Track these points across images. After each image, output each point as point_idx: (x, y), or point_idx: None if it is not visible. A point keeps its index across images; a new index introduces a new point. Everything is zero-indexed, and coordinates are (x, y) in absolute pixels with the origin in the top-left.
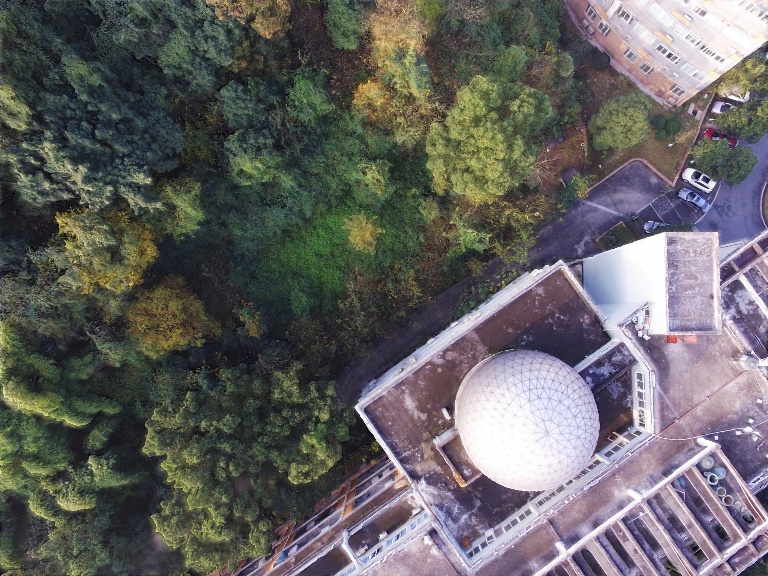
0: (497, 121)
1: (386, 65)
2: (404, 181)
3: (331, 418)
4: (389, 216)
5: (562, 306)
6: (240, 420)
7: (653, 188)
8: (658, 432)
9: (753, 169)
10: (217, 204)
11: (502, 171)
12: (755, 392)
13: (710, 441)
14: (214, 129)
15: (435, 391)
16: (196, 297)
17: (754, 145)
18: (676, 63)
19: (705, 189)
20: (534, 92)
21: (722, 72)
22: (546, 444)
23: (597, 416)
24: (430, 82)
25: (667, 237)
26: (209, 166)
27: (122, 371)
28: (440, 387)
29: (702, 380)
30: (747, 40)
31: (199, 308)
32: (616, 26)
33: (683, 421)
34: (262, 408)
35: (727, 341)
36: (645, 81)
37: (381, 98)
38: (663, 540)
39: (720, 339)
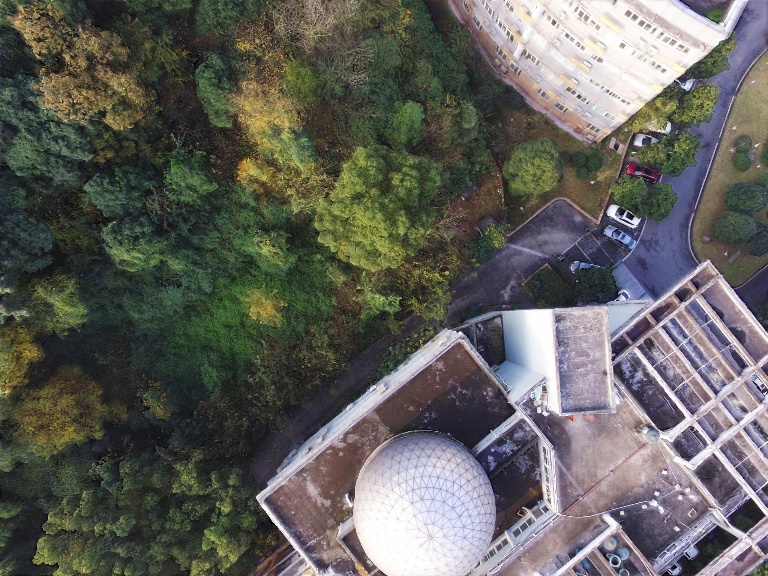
0: (380, 197)
1: (264, 142)
2: (309, 246)
3: (235, 508)
4: (298, 282)
5: (464, 380)
6: (134, 522)
7: (578, 227)
8: (562, 511)
9: (679, 201)
10: (109, 289)
11: (393, 245)
12: (660, 463)
13: (612, 520)
14: (93, 217)
15: (337, 476)
16: (94, 386)
17: (679, 176)
18: (587, 103)
19: (630, 225)
20: (420, 162)
21: (631, 114)
22: (430, 548)
23: (490, 507)
24: (317, 153)
25: (555, 314)
26: (93, 254)
27: (21, 468)
28: (342, 472)
29: (605, 454)
30: (646, 87)
31: (94, 400)
32: (525, 67)
33: (587, 497)
34: (163, 502)
35: (629, 412)
36: (562, 118)
37: (264, 175)
38: None
39: (622, 410)
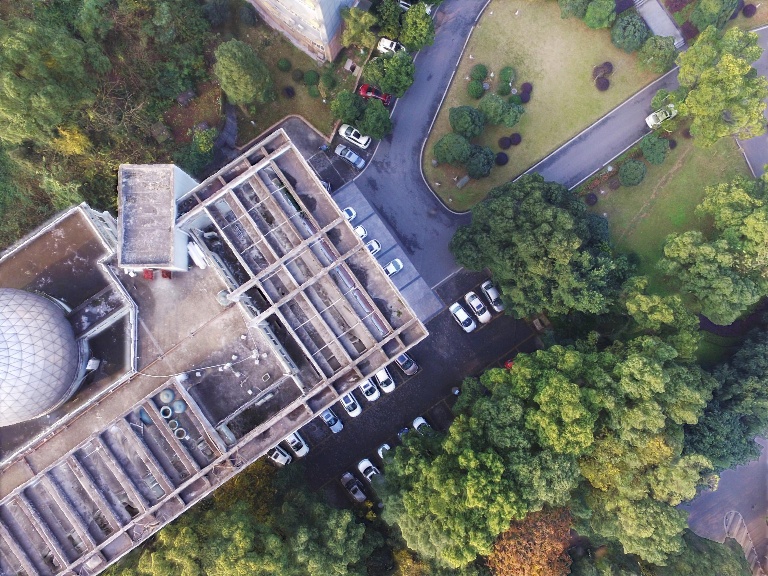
0: None
1: None
2: None
3: None
4: None
5: (82, 248)
6: None
7: (311, 145)
8: (141, 369)
9: (413, 125)
10: None
11: (15, 111)
12: (241, 328)
13: None
14: None
15: None
16: None
17: (414, 101)
18: None
19: (359, 145)
20: (40, 31)
21: (321, 20)
22: None
23: (37, 349)
24: None
25: (124, 170)
26: None
27: None
28: None
29: (188, 317)
30: None
31: None
32: None
33: (167, 358)
34: None
35: (215, 277)
36: (295, 36)
37: None
38: (119, 475)
39: (208, 275)
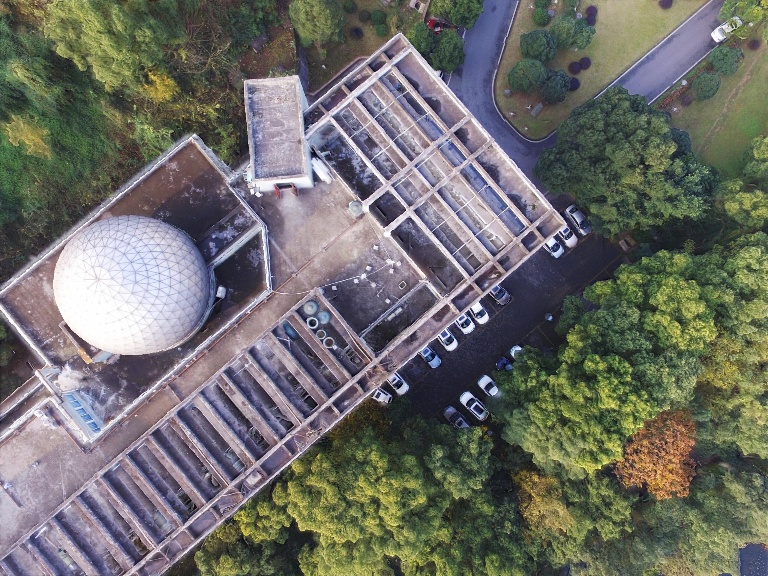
0: None
1: None
2: (85, 86)
3: None
4: (78, 124)
5: (197, 179)
6: None
7: None
8: (276, 288)
9: (482, 58)
10: None
11: (121, 48)
12: (372, 239)
13: None
14: None
15: None
16: None
17: (481, 34)
18: None
19: None
20: None
21: None
22: (97, 290)
23: (181, 268)
24: None
25: (249, 85)
26: None
27: None
28: None
29: (318, 232)
30: None
31: None
32: None
33: (301, 275)
34: None
35: (341, 191)
36: None
37: None
38: (270, 390)
39: (334, 190)
